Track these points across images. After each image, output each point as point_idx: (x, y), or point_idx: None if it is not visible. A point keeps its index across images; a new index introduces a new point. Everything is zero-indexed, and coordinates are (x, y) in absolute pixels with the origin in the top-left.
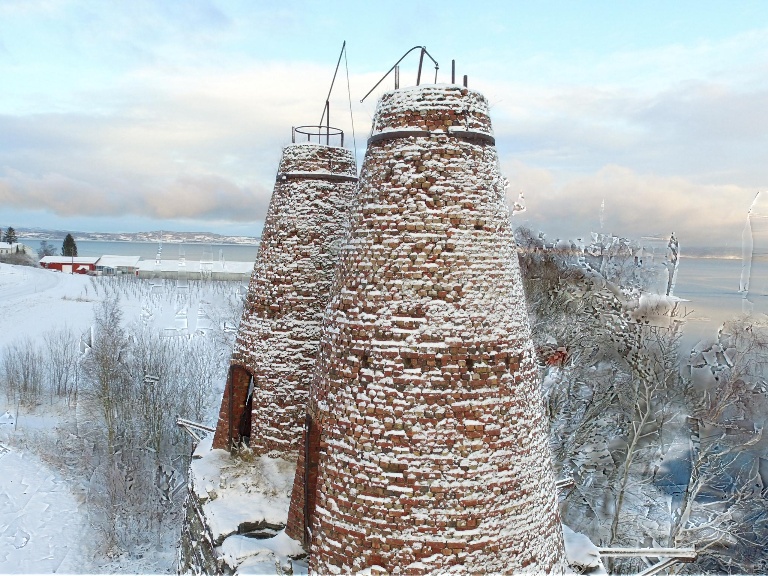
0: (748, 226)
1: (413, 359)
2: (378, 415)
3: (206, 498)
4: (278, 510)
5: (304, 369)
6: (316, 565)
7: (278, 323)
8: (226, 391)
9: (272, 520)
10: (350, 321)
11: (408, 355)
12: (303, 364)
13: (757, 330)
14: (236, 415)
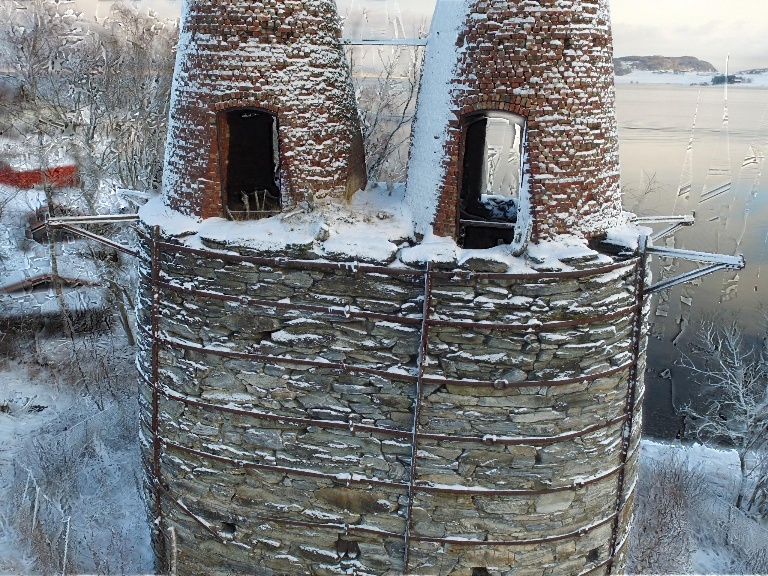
0: (354, 8)
1: (597, 39)
2: (583, 87)
3: (312, 242)
4: (391, 229)
5: (329, 100)
6: (546, 219)
7: (294, 48)
8: (213, 145)
9: (394, 237)
10: (548, 8)
11: (595, 35)
12: (328, 94)
13: (390, 93)
14: (224, 174)
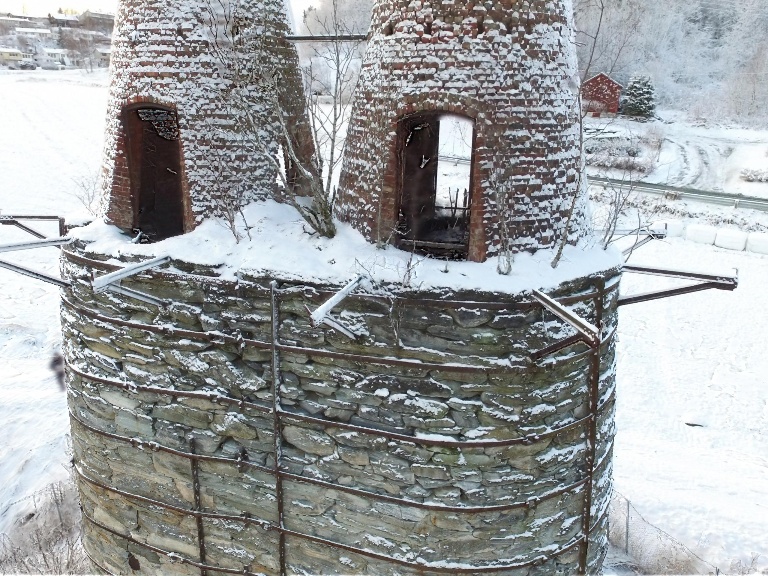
0: None
1: None
2: None
3: None
4: None
5: None
6: None
7: None
8: None
9: None
10: None
11: None
12: None
13: None
14: None
